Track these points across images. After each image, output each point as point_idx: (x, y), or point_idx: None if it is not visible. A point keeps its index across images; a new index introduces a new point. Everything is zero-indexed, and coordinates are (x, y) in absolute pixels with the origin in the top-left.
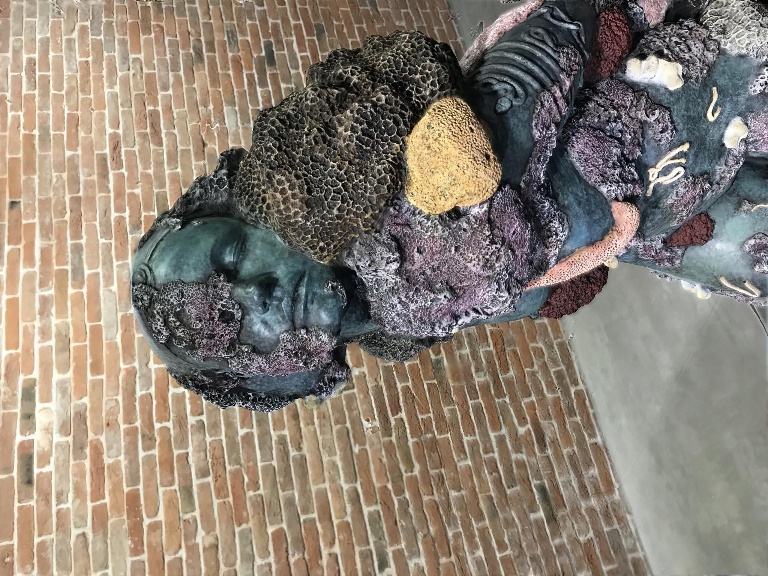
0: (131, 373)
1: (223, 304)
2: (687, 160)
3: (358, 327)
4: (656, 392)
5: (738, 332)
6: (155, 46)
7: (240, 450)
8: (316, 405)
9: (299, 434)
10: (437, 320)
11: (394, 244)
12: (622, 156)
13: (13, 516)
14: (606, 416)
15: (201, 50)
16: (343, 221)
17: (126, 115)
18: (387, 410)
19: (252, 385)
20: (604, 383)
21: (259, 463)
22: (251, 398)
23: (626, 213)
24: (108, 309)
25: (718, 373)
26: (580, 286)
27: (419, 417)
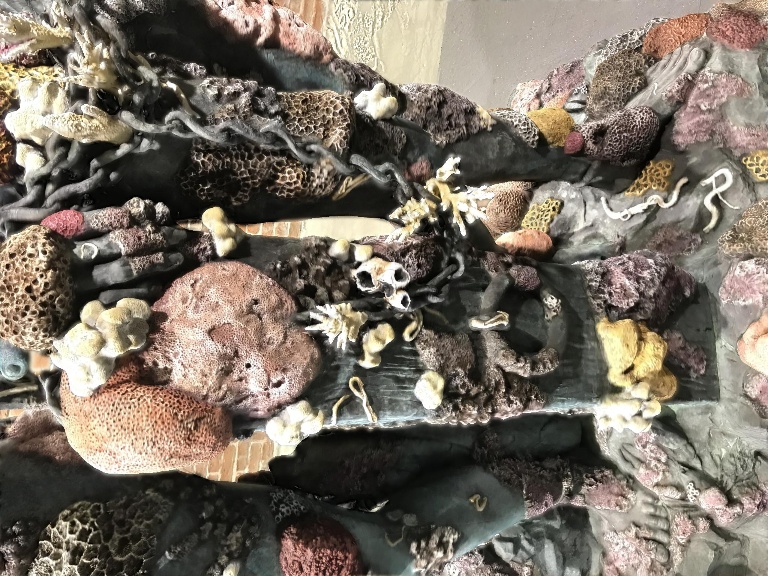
0: None
1: None
2: None
3: None
4: None
5: None
6: None
7: None
8: None
9: None
10: None
11: None
12: None
13: None
14: None
15: None
16: None
17: None
18: None
19: None
20: None
21: None
22: None
23: None
24: None
25: None
26: None
27: None
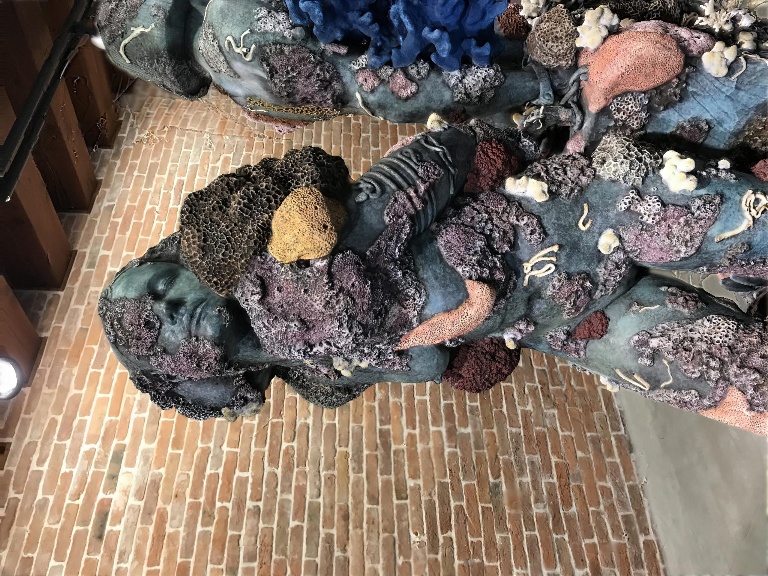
0: (205, 452)
1: (147, 315)
2: (559, 259)
3: (255, 352)
4: (725, 550)
5: None
6: None
7: (288, 541)
8: (229, 416)
9: (346, 536)
10: (293, 344)
11: (259, 282)
12: (488, 248)
13: (80, 566)
14: (676, 573)
15: None
16: (229, 264)
17: None
18: (437, 527)
19: (182, 391)
20: (675, 535)
21: (303, 557)
22: (181, 402)
23: (477, 290)
24: None
25: None
26: (484, 362)
27: (469, 539)
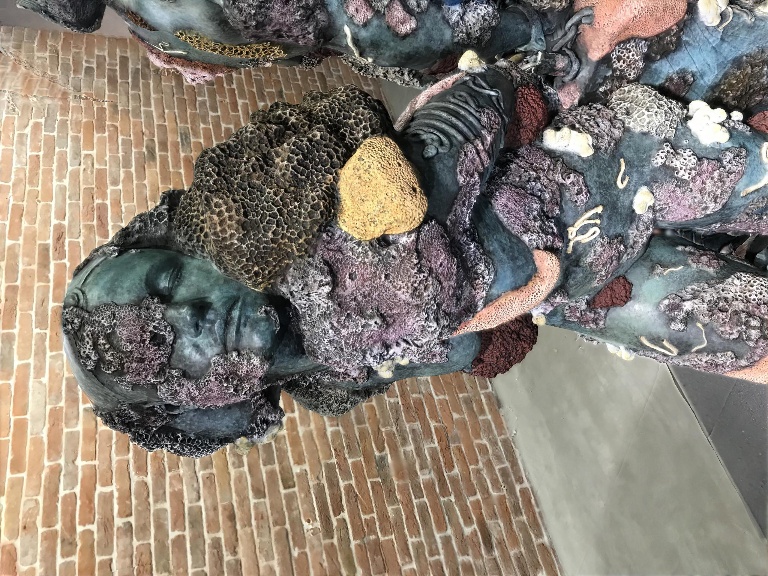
0: (55, 470)
1: (155, 326)
2: (602, 221)
3: (292, 362)
4: (599, 487)
5: (672, 422)
6: (108, 144)
7: (170, 555)
8: (247, 448)
9: (235, 537)
10: (368, 348)
11: (326, 268)
12: (542, 212)
13: None
14: (552, 515)
15: (154, 149)
16: (278, 246)
17: (73, 207)
18: (329, 510)
19: (182, 424)
20: (548, 480)
21: (190, 569)
22: (180, 439)
23: (547, 261)
24: (36, 402)
25: (656, 464)
26: (511, 343)
27: (362, 517)
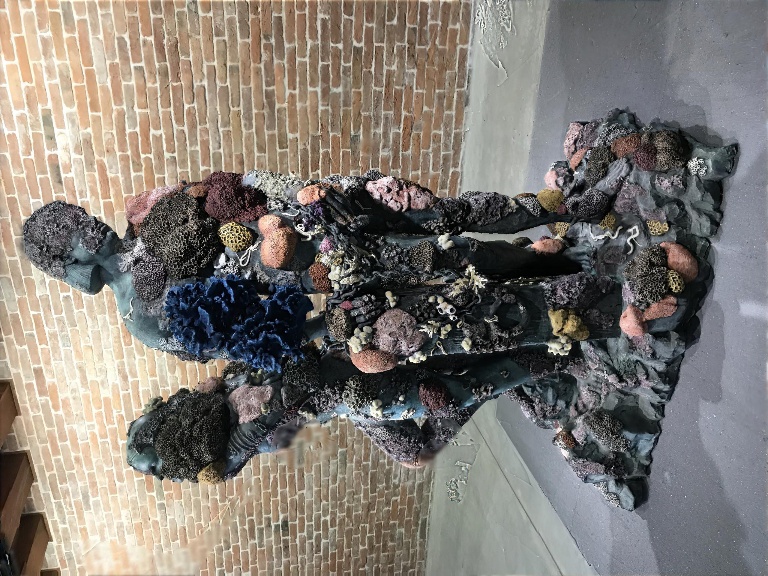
0: (121, 114)
1: None
2: None
3: None
4: None
5: None
6: None
7: None
8: None
9: None
10: None
11: None
12: None
13: None
14: None
15: None
16: None
17: None
18: (309, 167)
19: None
20: (471, 179)
21: None
22: None
23: None
24: (98, 56)
25: None
26: None
27: None
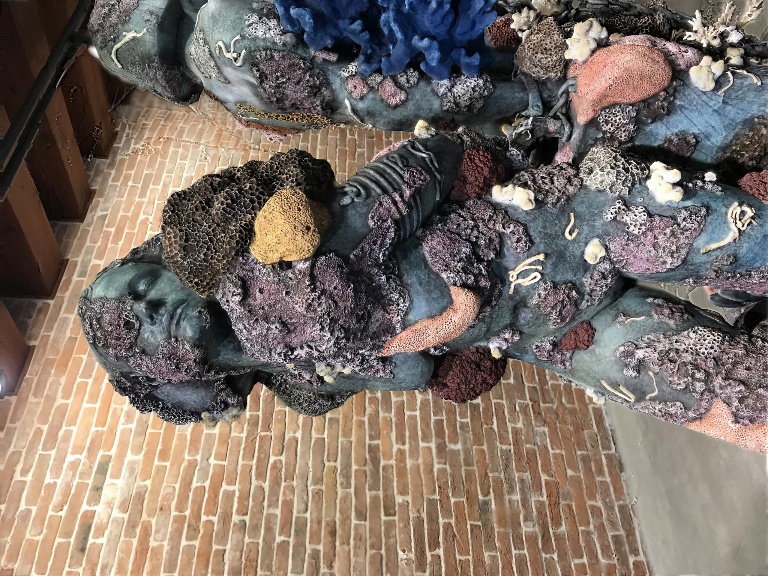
0: (192, 465)
1: (127, 315)
2: (544, 268)
3: (236, 355)
4: (714, 571)
5: None
6: None
7: (274, 557)
8: (209, 421)
9: (333, 552)
10: (273, 347)
11: (240, 283)
12: (473, 255)
13: None
14: None
15: None
16: (210, 264)
17: None
18: (425, 544)
19: (161, 395)
20: (665, 556)
21: (289, 574)
22: (161, 406)
23: (462, 296)
24: None
25: None
26: (469, 371)
27: (457, 558)
